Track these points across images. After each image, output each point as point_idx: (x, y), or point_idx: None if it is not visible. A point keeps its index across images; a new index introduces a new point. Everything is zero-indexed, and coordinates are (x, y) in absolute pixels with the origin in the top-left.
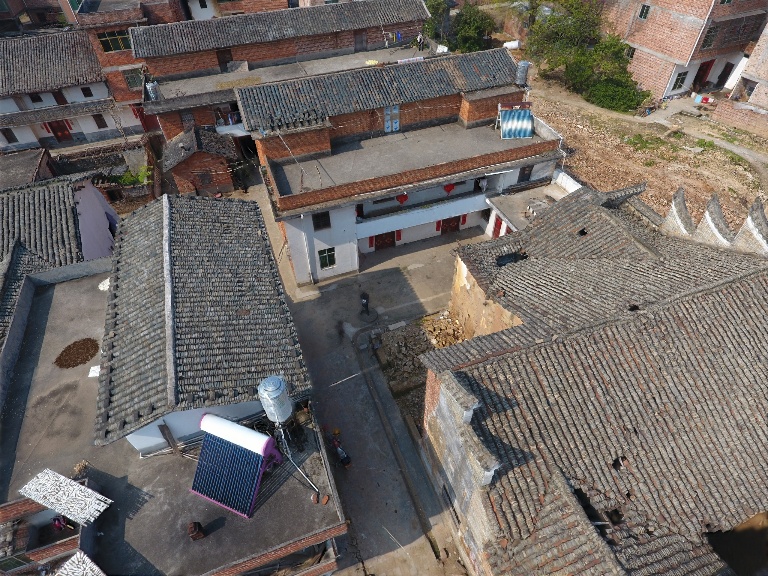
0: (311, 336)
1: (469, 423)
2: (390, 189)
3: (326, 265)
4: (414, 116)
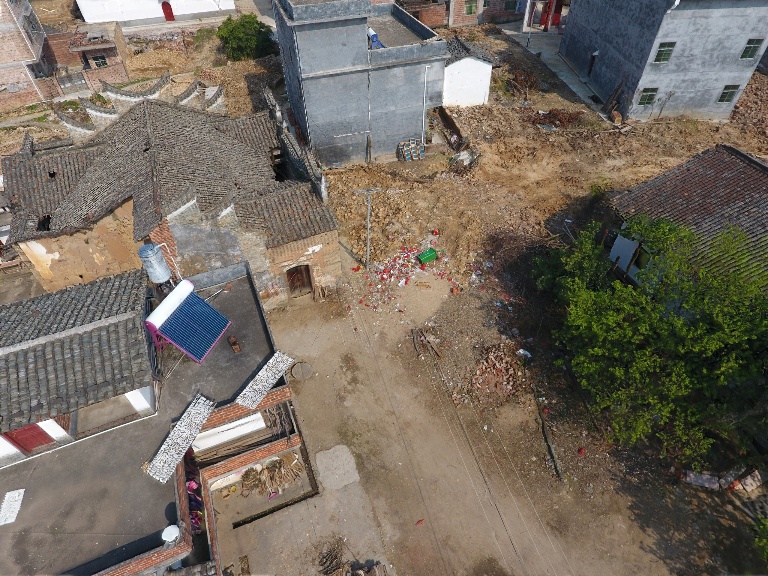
0: None
1: (201, 212)
2: None
3: None
4: None
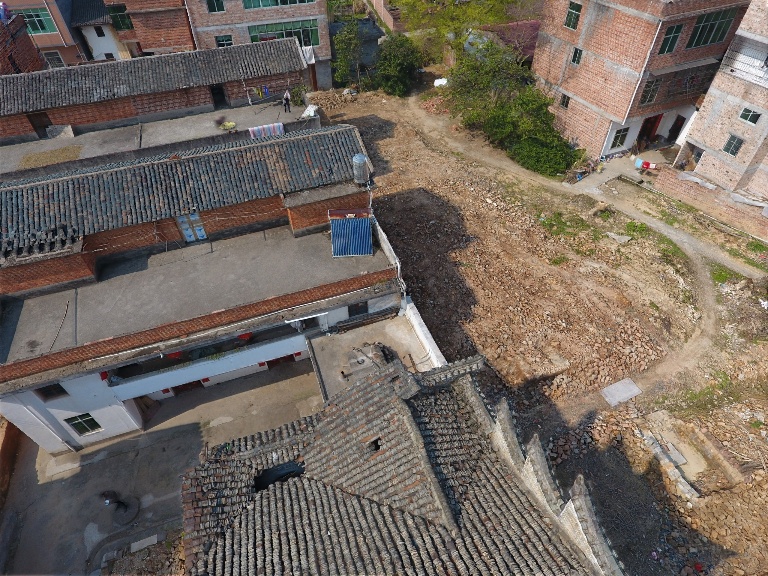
0: (35, 549)
1: None
2: (144, 348)
3: (87, 430)
4: (223, 222)
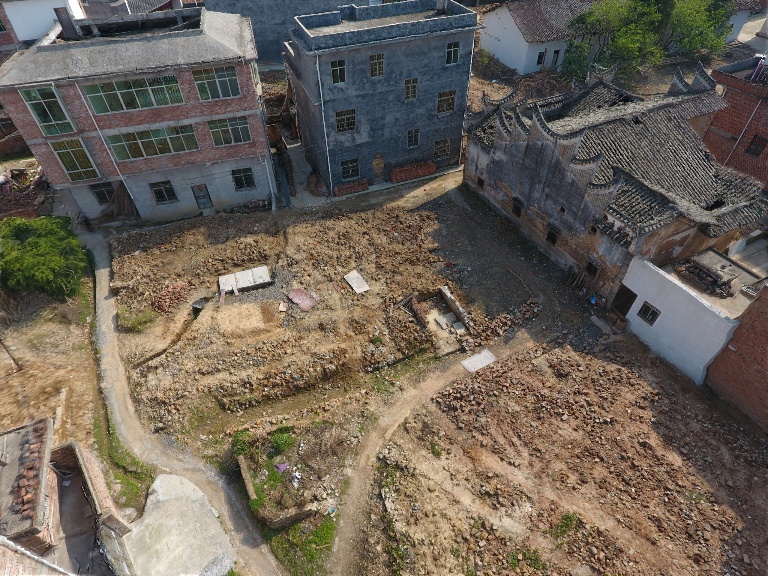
0: None
1: None
2: None
3: None
4: None
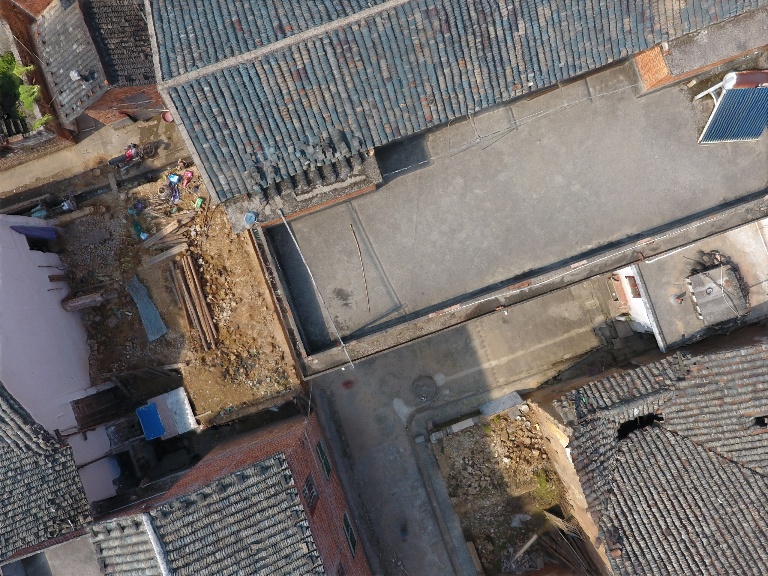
0: (356, 419)
1: None
2: (481, 301)
3: None
4: None
